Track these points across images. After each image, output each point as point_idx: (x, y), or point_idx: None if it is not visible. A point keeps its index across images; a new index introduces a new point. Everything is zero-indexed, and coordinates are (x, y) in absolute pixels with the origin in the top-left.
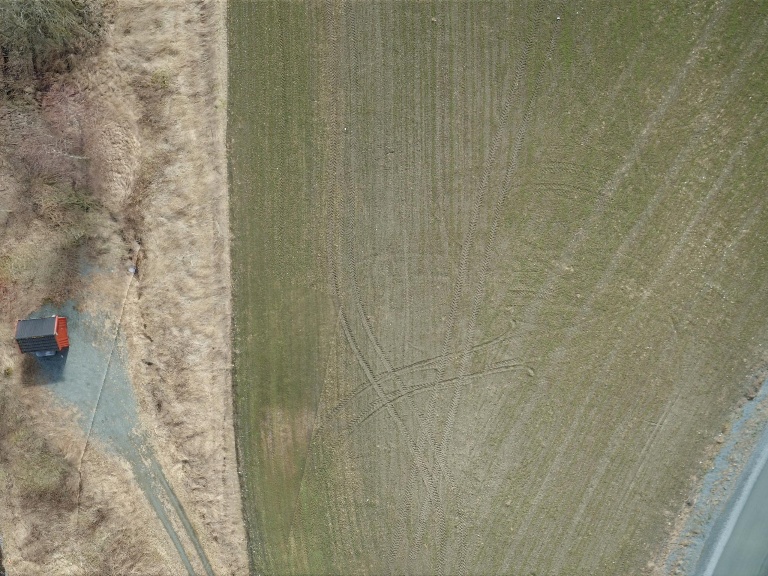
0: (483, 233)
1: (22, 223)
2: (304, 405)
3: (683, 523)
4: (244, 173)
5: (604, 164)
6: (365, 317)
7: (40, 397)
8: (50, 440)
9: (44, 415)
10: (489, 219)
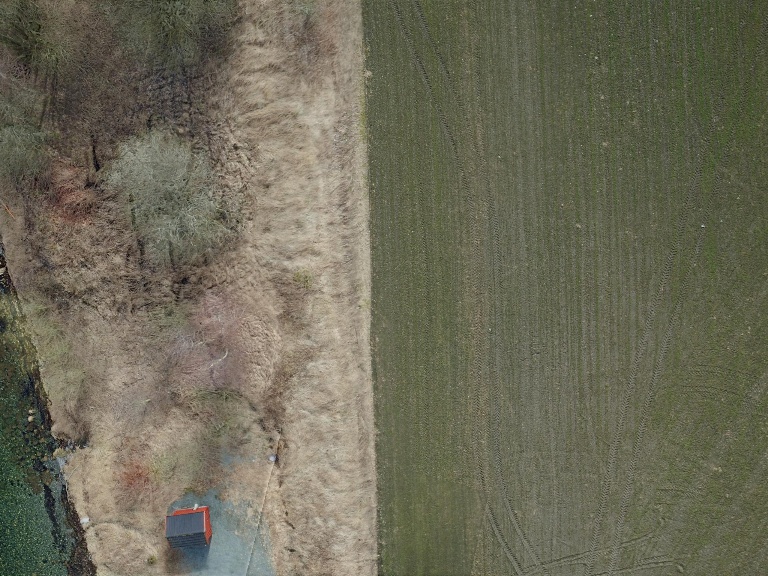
0: (630, 433)
1: (160, 411)
2: None
3: None
4: (389, 371)
5: (750, 368)
6: (512, 512)
7: None
8: None
9: None
10: (636, 420)
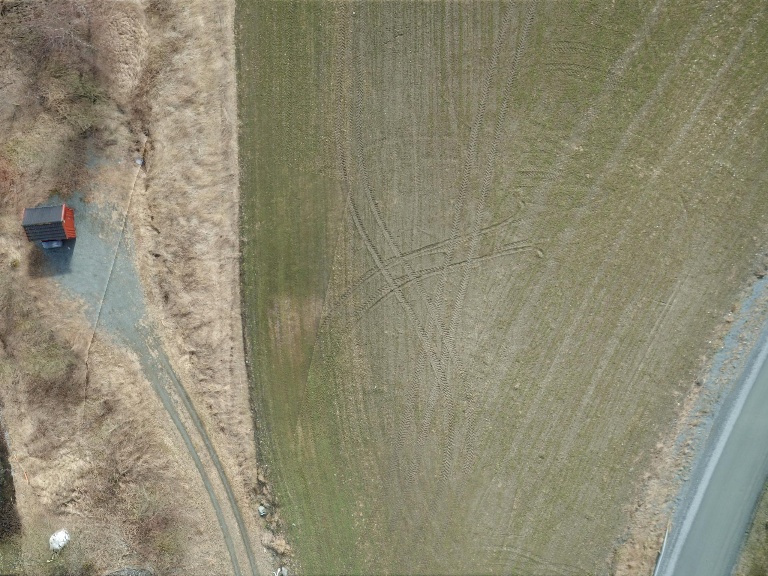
0: (492, 114)
1: (29, 116)
2: (312, 293)
3: (692, 403)
4: (252, 59)
5: (614, 43)
6: (373, 202)
7: (47, 289)
8: (57, 332)
9: (51, 307)
10: (498, 100)
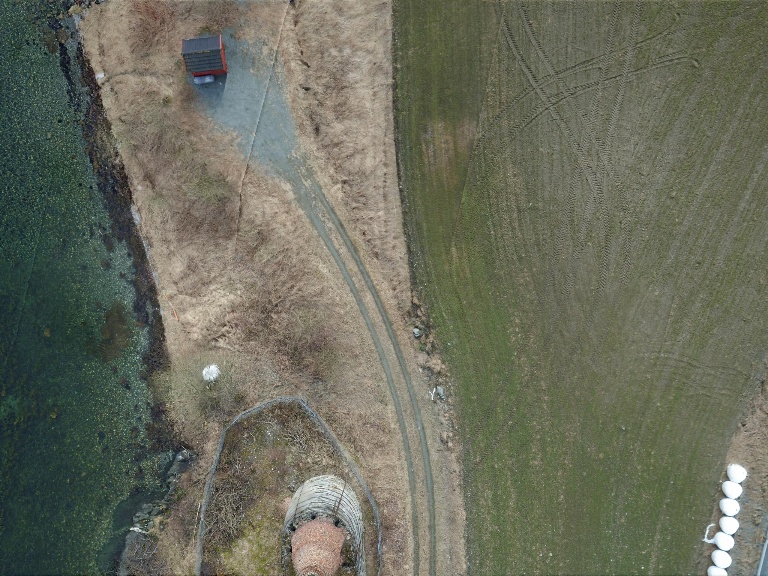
0: None
1: None
2: (465, 115)
3: None
4: None
5: None
6: (527, 22)
7: (200, 123)
8: (210, 165)
9: (204, 141)
10: None
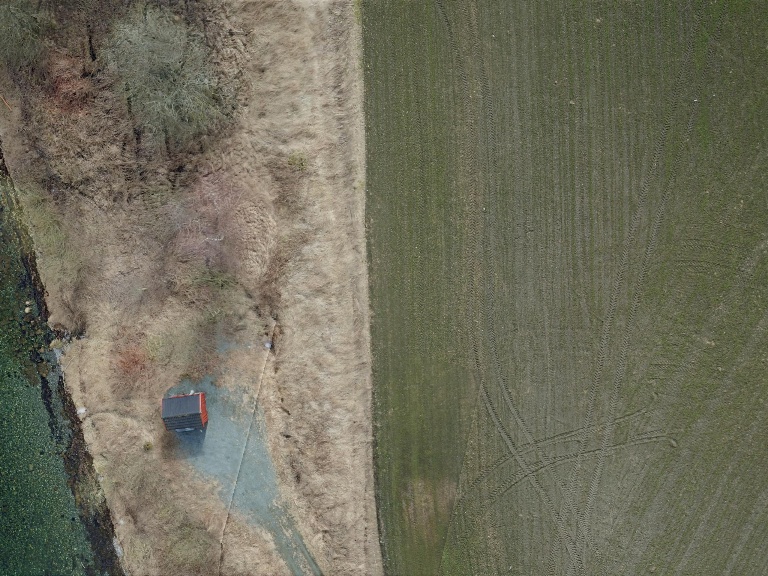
0: (624, 309)
1: (156, 300)
2: (445, 476)
3: None
4: (383, 252)
5: (743, 241)
6: (506, 391)
7: (180, 471)
8: (191, 513)
9: (185, 489)
10: (630, 295)
